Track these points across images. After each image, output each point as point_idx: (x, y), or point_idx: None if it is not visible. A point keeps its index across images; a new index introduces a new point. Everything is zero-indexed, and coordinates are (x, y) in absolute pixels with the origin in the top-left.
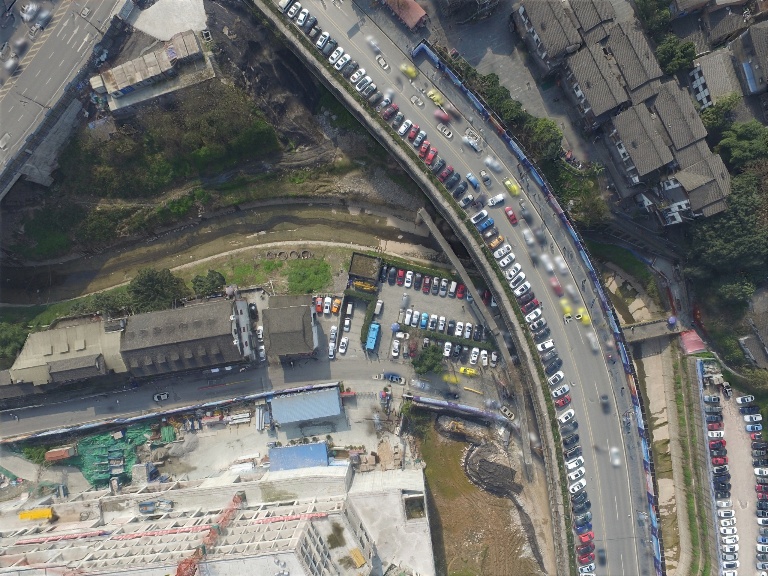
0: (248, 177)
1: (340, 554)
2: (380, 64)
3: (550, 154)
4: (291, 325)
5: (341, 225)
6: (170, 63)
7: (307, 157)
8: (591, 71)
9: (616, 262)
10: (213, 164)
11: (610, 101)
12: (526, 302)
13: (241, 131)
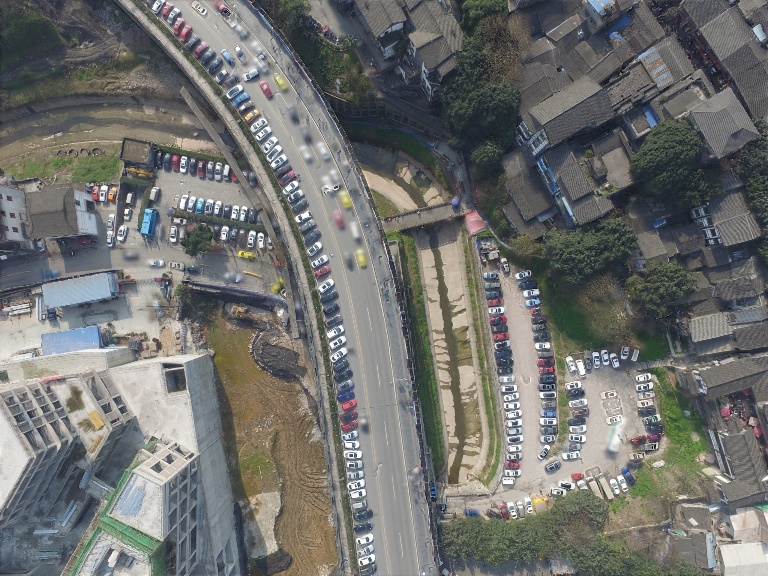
0: (33, 74)
1: (79, 417)
2: None
3: (293, 22)
4: (52, 206)
5: (137, 124)
6: None
7: (92, 53)
8: None
9: (404, 149)
10: None
11: None
12: (282, 174)
13: (11, 22)
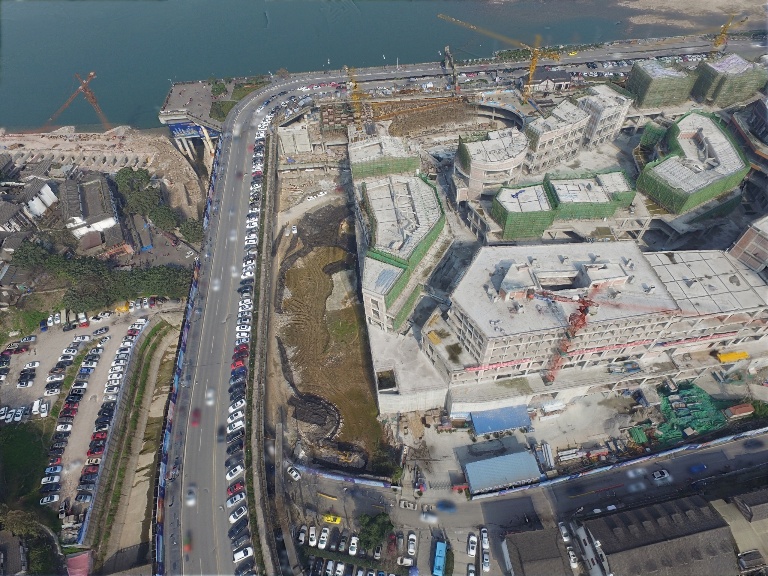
0: None
1: (449, 340)
2: None
3: None
4: (538, 570)
5: None
6: None
7: None
8: None
9: None
10: None
11: None
12: None
13: None
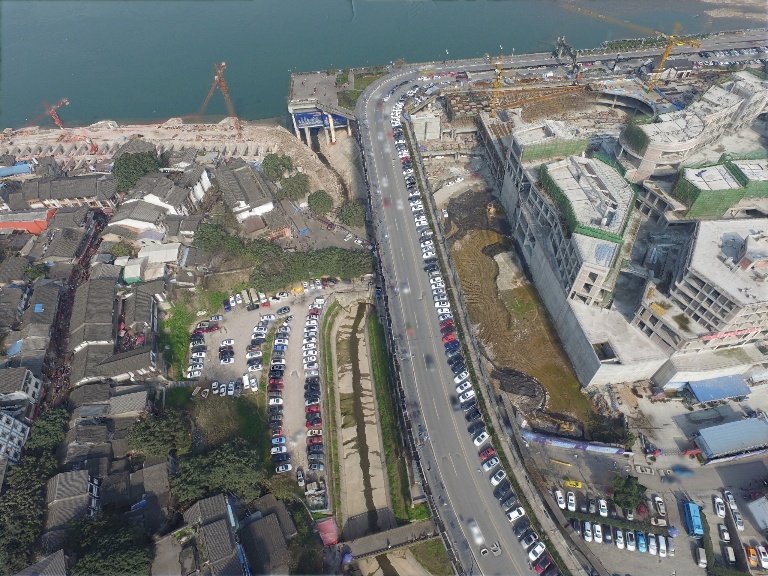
0: None
1: (673, 311)
2: None
3: None
4: None
5: None
6: None
7: None
8: None
9: None
10: None
11: None
12: (550, 569)
13: None
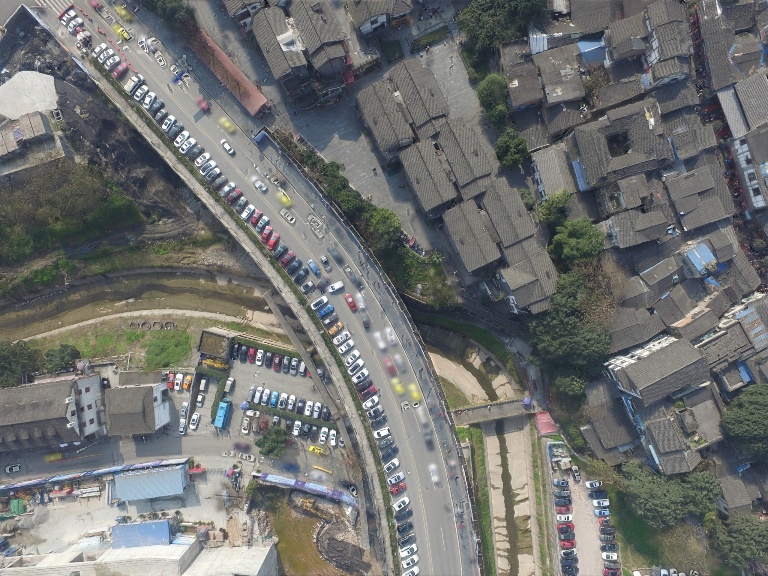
0: (111, 248)
1: None
2: (225, 148)
3: None
4: (131, 406)
5: (209, 294)
6: (16, 144)
7: (170, 229)
8: (420, 167)
9: (476, 340)
10: (75, 235)
11: (437, 198)
12: (363, 389)
13: (96, 207)
